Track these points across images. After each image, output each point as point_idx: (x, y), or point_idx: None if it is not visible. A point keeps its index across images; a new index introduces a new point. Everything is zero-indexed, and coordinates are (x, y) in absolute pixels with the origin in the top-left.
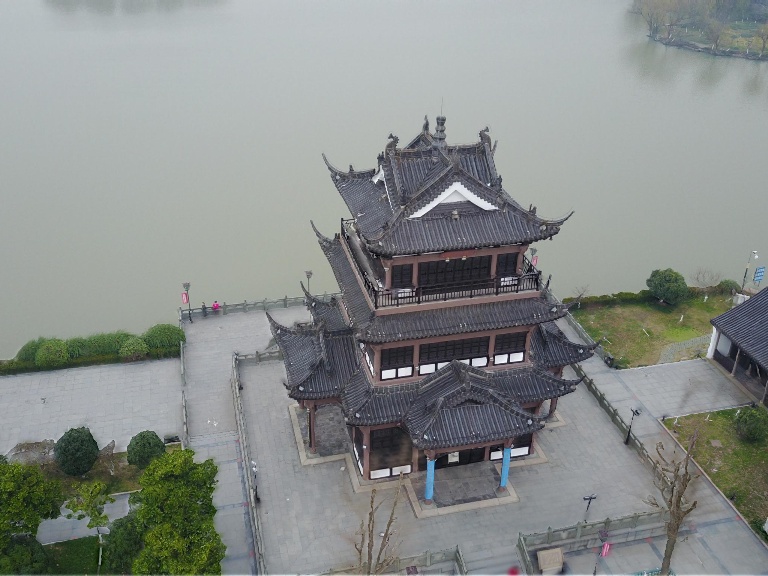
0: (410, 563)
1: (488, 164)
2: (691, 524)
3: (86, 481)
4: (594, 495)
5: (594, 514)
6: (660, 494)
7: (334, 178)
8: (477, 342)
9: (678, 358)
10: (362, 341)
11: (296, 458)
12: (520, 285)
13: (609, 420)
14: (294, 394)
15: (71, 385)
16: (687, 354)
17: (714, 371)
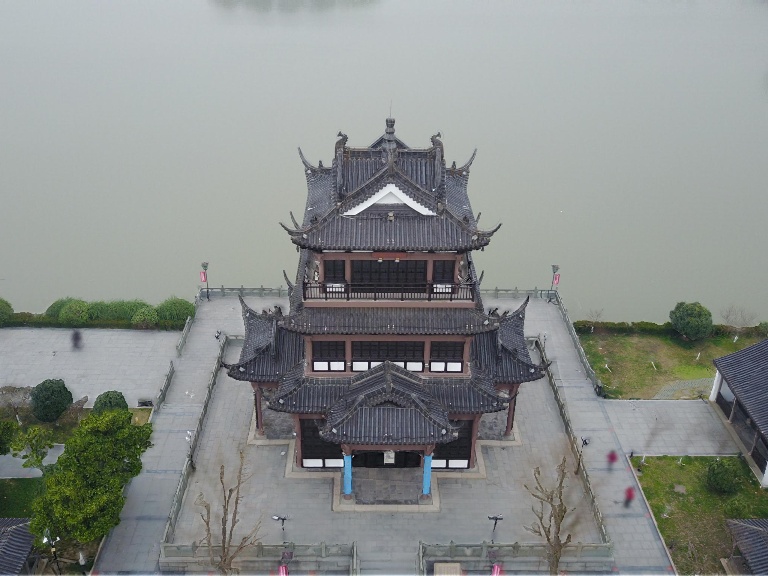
0: (305, 551)
1: (436, 169)
2: (615, 565)
3: (58, 429)
4: (499, 516)
5: (511, 537)
6: (590, 529)
7: (306, 172)
8: (412, 346)
9: (677, 396)
10: (285, 329)
11: (245, 437)
12: (454, 294)
13: (568, 447)
14: (234, 373)
15: (82, 343)
16: (690, 393)
17: (712, 415)
